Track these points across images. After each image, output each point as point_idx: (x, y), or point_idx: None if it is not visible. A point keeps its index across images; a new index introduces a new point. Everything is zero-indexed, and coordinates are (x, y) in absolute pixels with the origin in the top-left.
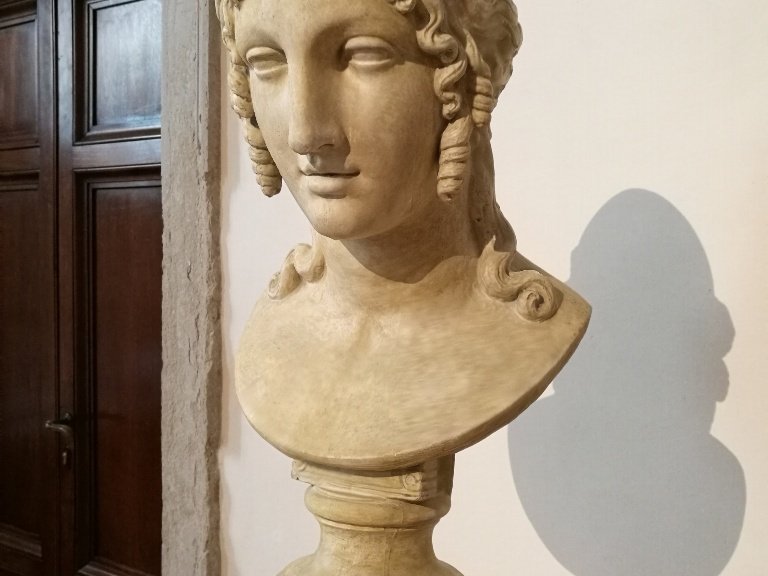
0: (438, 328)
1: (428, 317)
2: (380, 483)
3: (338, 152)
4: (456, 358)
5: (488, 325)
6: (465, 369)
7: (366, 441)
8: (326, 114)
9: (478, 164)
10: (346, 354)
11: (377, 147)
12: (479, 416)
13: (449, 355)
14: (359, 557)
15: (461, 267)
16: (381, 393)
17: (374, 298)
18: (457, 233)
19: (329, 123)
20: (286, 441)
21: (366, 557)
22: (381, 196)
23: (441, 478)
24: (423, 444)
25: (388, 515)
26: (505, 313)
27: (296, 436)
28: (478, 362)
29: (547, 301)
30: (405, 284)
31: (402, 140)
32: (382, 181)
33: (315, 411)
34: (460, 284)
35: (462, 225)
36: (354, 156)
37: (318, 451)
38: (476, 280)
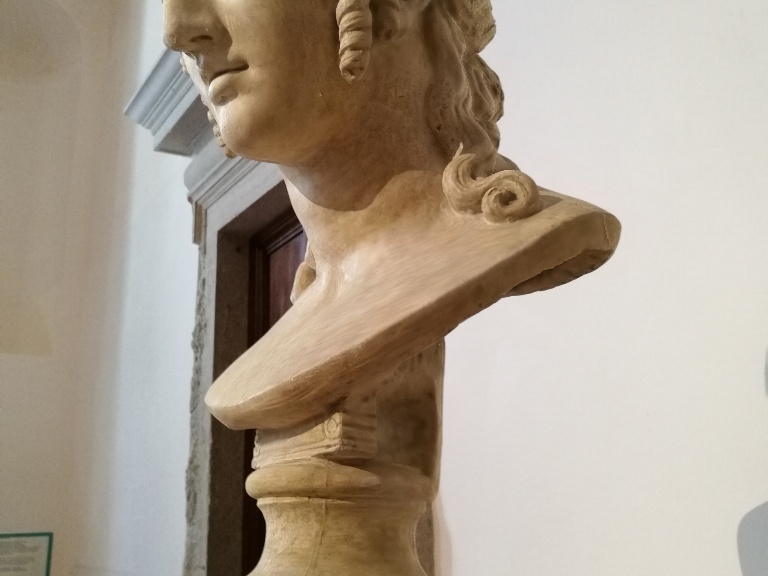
0: (395, 257)
1: (386, 248)
2: (306, 439)
3: (220, 46)
4: (400, 277)
5: (449, 239)
6: (403, 283)
7: (273, 374)
8: (197, 4)
9: (440, 73)
10: (309, 313)
11: (254, 28)
12: (391, 318)
13: (395, 277)
14: (285, 542)
15: (421, 184)
16: (312, 329)
17: (331, 240)
18: (408, 143)
19: (201, 13)
20: (216, 402)
21: (292, 542)
22: (274, 87)
23: (416, 453)
24: (321, 360)
25: (306, 475)
26: (473, 224)
27: (225, 394)
28: (420, 273)
29: (521, 197)
30: (355, 212)
31: (279, 15)
32: (271, 68)
33: (252, 366)
34: (422, 204)
35: (416, 135)
36: (237, 46)
37: (234, 401)
38: (445, 199)
